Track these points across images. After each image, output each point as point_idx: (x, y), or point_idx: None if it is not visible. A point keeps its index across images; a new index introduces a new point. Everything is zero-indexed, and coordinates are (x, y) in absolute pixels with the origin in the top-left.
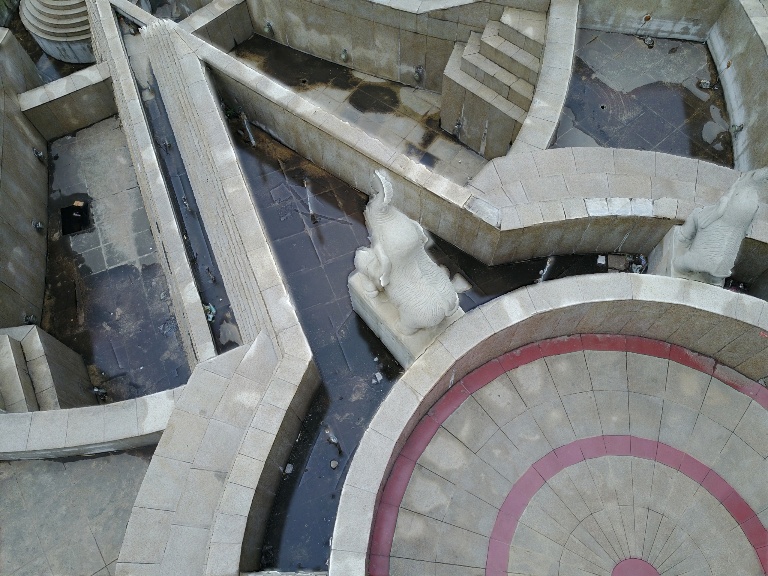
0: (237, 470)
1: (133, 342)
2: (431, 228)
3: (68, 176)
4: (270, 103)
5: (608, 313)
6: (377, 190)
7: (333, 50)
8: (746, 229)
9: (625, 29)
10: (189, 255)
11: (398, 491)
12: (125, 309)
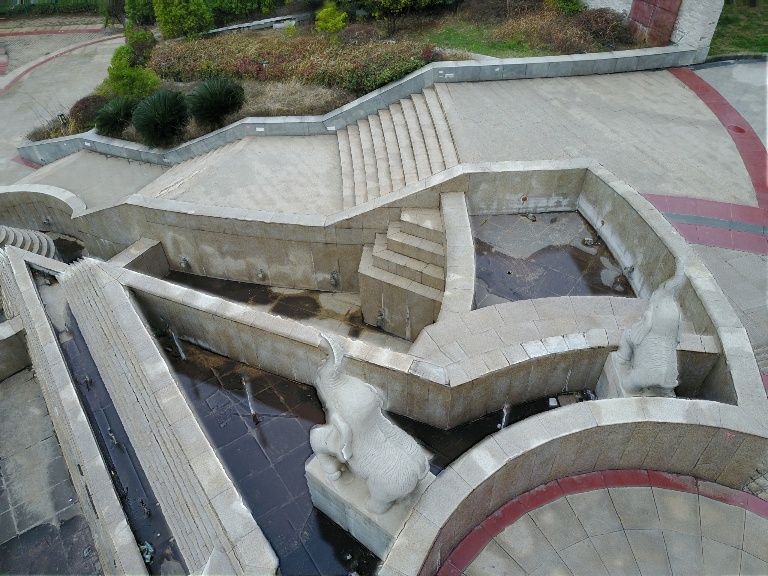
0: None
1: None
2: None
3: None
4: (198, 312)
5: (578, 448)
6: (326, 352)
7: (250, 272)
8: (676, 337)
9: (508, 210)
10: (118, 491)
11: None
12: None
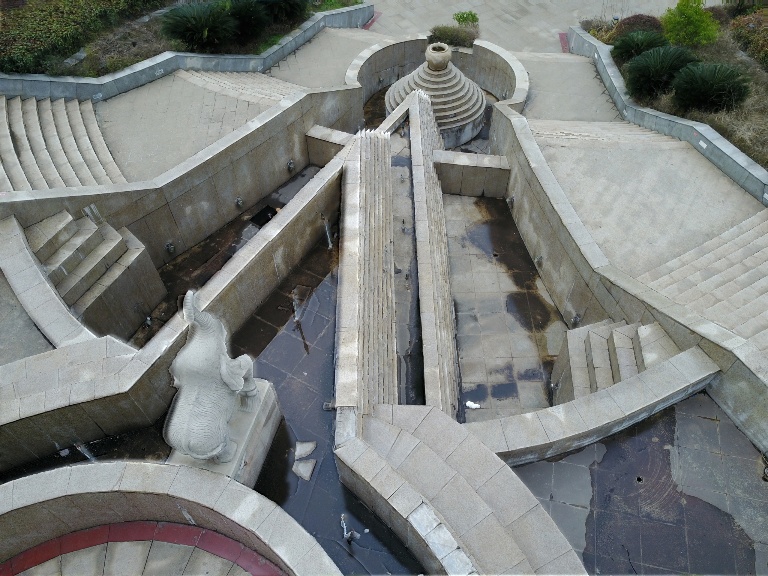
0: (6, 406)
1: None
2: None
3: (294, 191)
4: None
5: None
6: None
7: (536, 250)
8: None
9: (755, 439)
10: None
11: (75, 545)
12: None
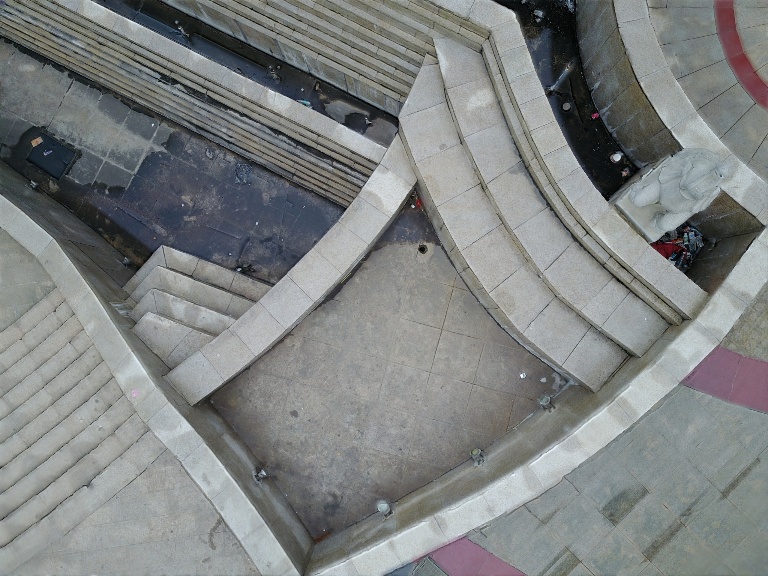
0: (541, 143)
1: (227, 211)
2: None
3: None
4: None
5: None
6: None
7: None
8: None
9: None
10: None
11: None
12: (189, 192)
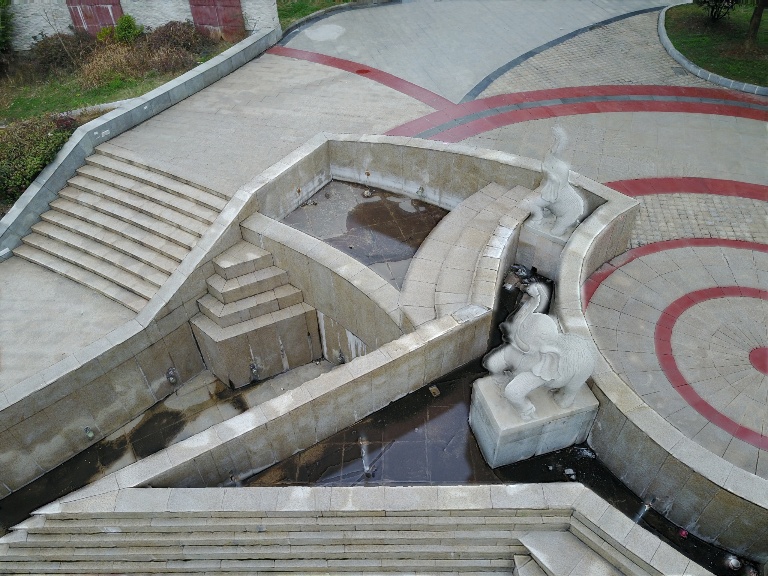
0: None
1: None
2: (435, 376)
3: None
4: (247, 436)
5: None
6: (537, 294)
7: (72, 442)
8: None
9: (291, 208)
10: None
11: None
12: None
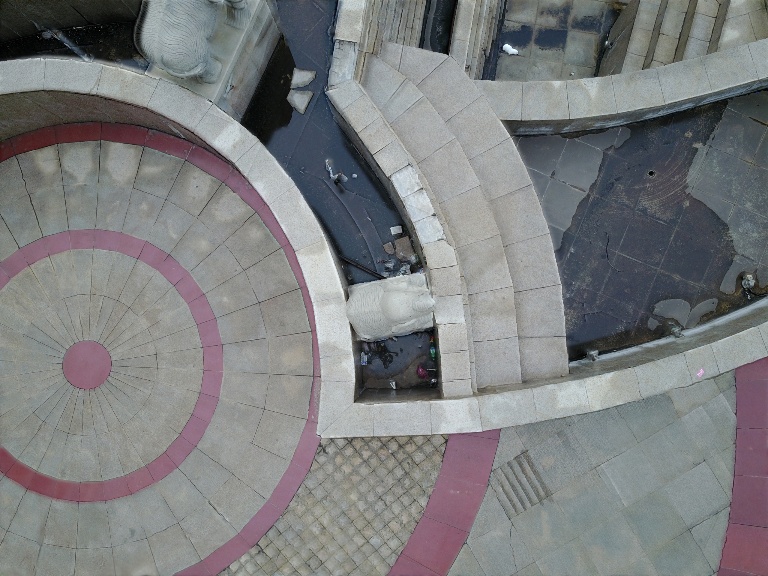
0: None
1: None
2: None
3: None
4: None
5: None
6: None
7: None
8: (392, 326)
9: None
10: None
11: (69, 136)
12: None
